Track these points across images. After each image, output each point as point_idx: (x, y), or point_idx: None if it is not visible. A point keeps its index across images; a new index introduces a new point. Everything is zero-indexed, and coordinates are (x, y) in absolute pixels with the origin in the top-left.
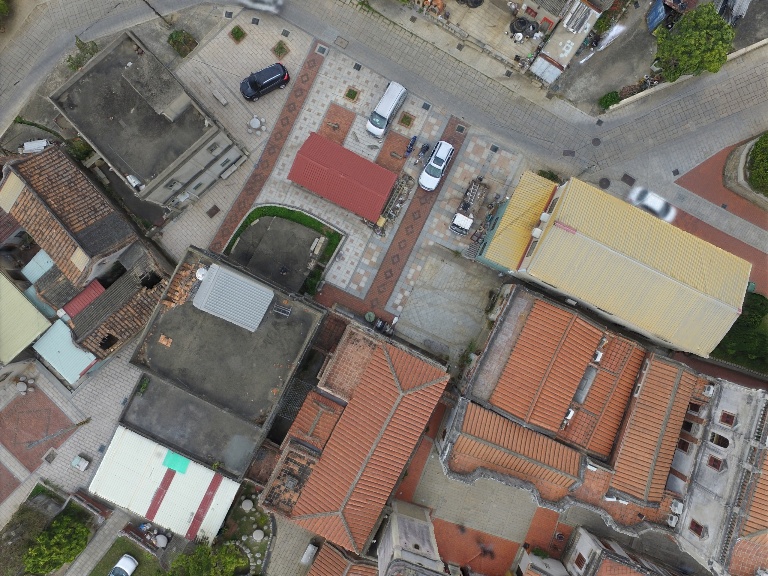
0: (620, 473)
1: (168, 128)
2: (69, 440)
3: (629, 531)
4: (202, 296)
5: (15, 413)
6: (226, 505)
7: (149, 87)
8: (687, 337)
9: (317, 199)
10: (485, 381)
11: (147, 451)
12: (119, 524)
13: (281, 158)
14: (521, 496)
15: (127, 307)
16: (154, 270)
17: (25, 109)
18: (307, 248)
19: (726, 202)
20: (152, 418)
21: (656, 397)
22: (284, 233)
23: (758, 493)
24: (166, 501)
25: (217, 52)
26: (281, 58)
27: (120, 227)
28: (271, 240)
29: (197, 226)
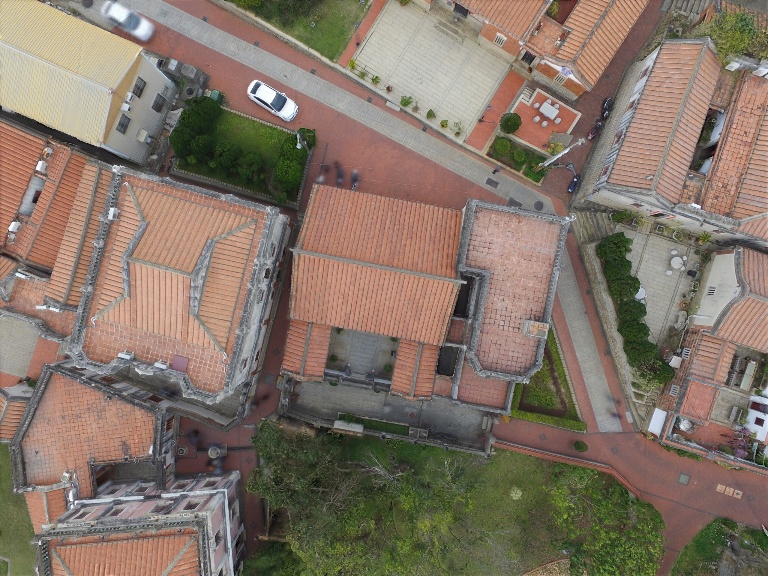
0: (53, 281)
1: None
2: None
3: (55, 337)
4: None
5: None
6: None
7: None
8: (73, 124)
9: None
10: None
11: None
12: None
13: None
14: (19, 328)
15: None
16: None
17: None
18: None
19: (207, 14)
20: None
21: (83, 200)
22: None
23: (110, 270)
24: None
25: None
26: None
27: None
28: None
29: None
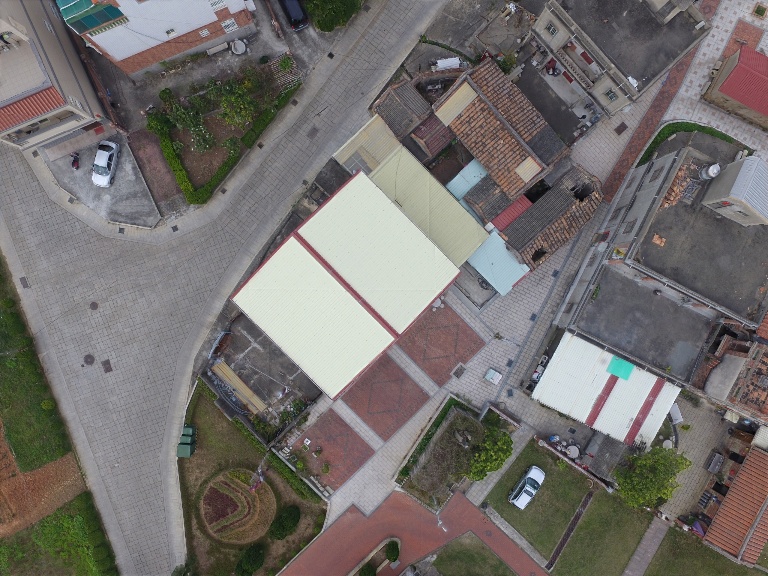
0: None
1: (659, 31)
2: (477, 355)
3: None
4: (742, 187)
5: (424, 329)
6: (665, 410)
7: None
8: None
9: (724, 115)
10: None
11: (591, 358)
12: (524, 437)
13: (689, 75)
14: None
15: (561, 219)
16: (587, 182)
17: (430, 28)
18: (729, 161)
19: None
20: (600, 325)
21: None
22: (707, 147)
23: None
24: (606, 407)
25: None
26: None
27: (555, 140)
28: None
29: (605, 143)
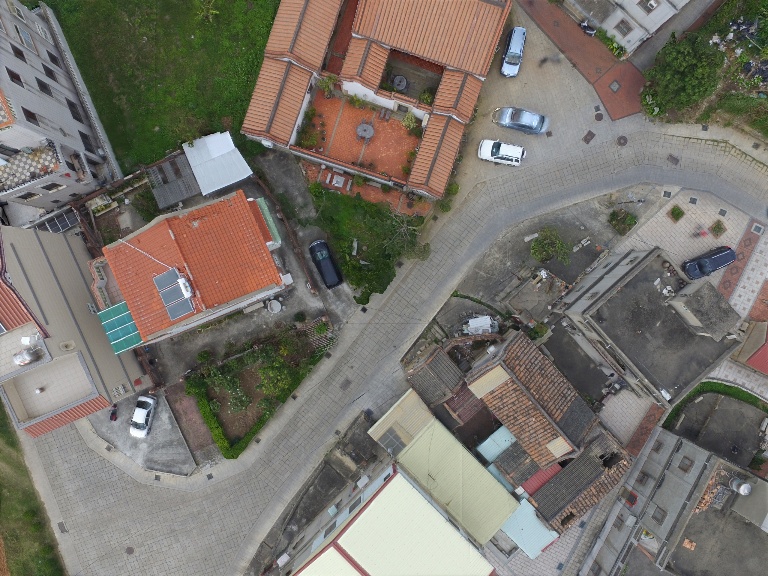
0: None
1: (691, 340)
2: None
3: None
4: None
5: None
6: None
7: (709, 316)
8: None
9: (750, 373)
10: None
11: None
12: None
13: None
14: None
15: (590, 487)
16: (616, 452)
17: (462, 284)
18: (755, 427)
19: None
20: None
21: None
22: (733, 412)
23: None
24: None
25: (656, 231)
26: (718, 237)
27: (585, 411)
28: (721, 419)
29: (633, 399)
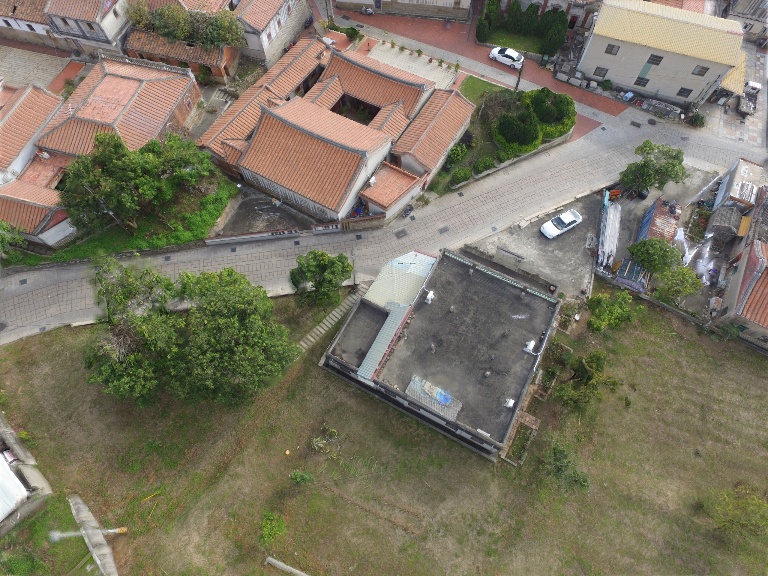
0: None
1: None
2: None
3: None
4: None
5: None
6: None
7: None
8: None
9: None
10: (711, 2)
11: None
12: None
13: None
14: None
15: None
16: None
17: None
18: None
19: None
20: None
21: None
22: None
23: None
24: None
25: None
26: None
27: None
28: None
29: None
